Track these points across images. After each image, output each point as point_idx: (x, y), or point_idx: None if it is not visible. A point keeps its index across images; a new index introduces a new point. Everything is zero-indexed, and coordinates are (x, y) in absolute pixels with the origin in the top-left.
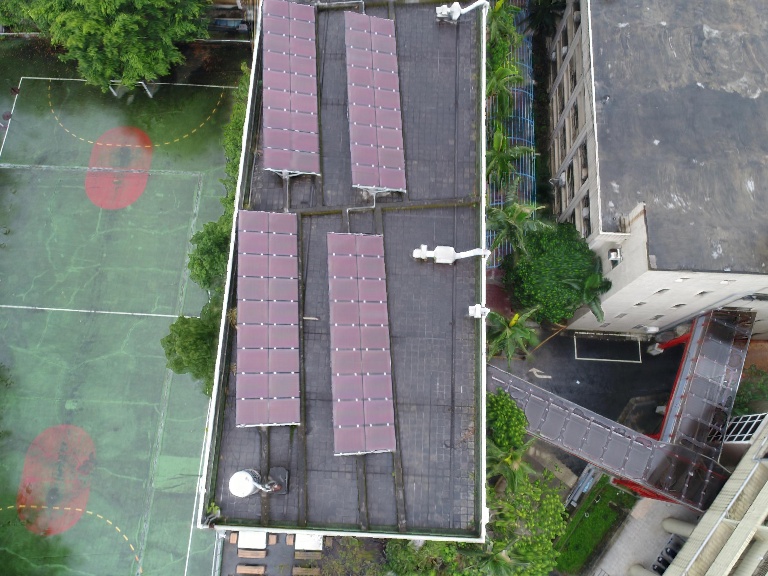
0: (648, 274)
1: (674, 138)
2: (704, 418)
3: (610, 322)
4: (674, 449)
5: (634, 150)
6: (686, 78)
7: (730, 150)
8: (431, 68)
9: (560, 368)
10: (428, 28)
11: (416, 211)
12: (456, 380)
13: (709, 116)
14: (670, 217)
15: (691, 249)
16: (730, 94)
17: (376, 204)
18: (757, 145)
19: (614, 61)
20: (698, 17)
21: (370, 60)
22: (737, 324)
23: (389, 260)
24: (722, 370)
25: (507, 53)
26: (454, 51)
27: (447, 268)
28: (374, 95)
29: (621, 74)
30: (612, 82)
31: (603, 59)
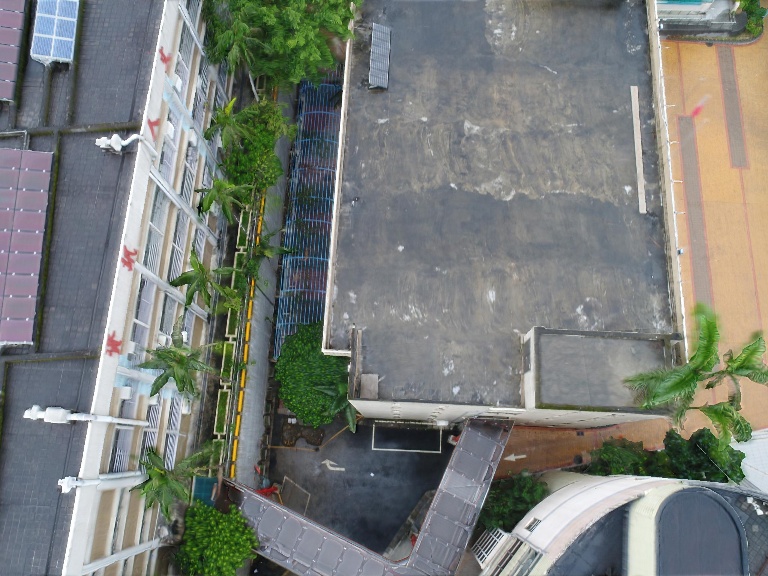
0: (353, 401)
1: (419, 244)
2: (458, 531)
3: None
4: (407, 572)
5: (377, 257)
6: (440, 178)
7: (475, 257)
8: (87, 204)
9: (355, 459)
10: (92, 159)
11: (44, 363)
12: (53, 553)
13: (458, 220)
14: (404, 330)
15: (422, 365)
16: (483, 196)
17: (0, 357)
18: (504, 252)
19: (368, 160)
20: (460, 112)
21: (13, 200)
22: (501, 430)
23: (7, 418)
24: (480, 480)
25: (265, 150)
26: (114, 185)
27: (65, 427)
28: (10, 239)
29: (374, 174)
30: (364, 183)
31: (357, 158)
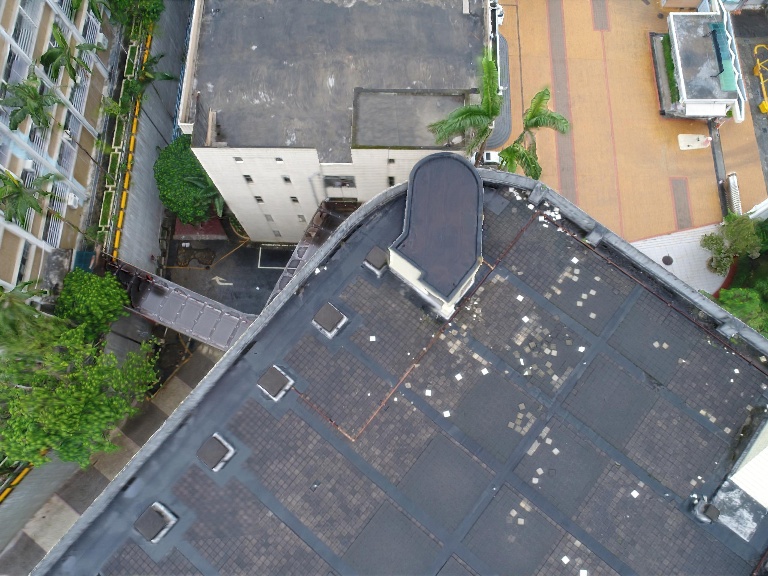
0: (198, 153)
1: (270, 44)
2: None
3: (276, 229)
4: None
5: (233, 55)
6: None
7: (318, 52)
8: None
9: (242, 276)
10: None
11: None
12: None
13: (305, 24)
14: (254, 111)
15: (268, 138)
16: (328, 4)
17: None
18: (343, 47)
19: None
20: None
21: None
22: None
23: None
24: None
25: None
26: None
27: None
28: None
29: None
30: None
31: None
